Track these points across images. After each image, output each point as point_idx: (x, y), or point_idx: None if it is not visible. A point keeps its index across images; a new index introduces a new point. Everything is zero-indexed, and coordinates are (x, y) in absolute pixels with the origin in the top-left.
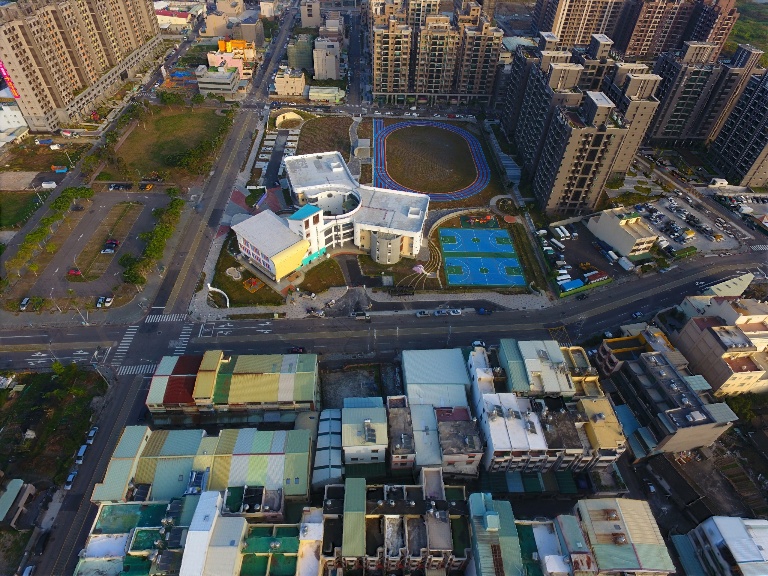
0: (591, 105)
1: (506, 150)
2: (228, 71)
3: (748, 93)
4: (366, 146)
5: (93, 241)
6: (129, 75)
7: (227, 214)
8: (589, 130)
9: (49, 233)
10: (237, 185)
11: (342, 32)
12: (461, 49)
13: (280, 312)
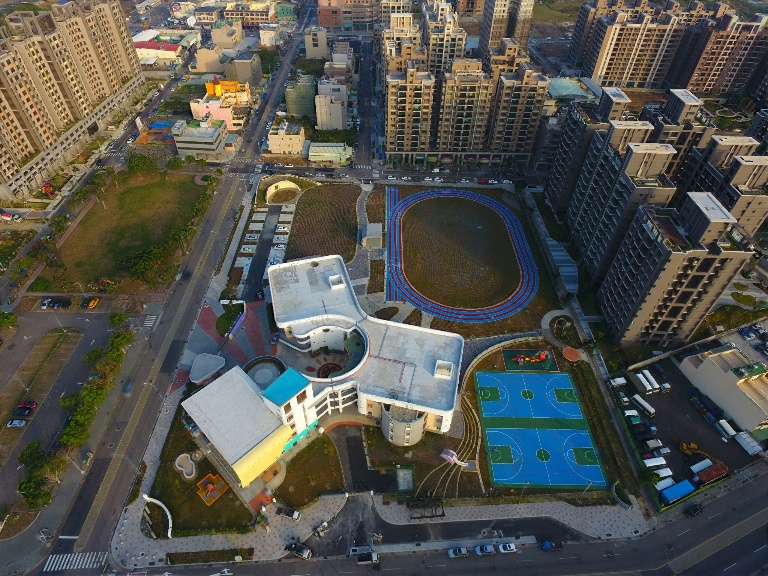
0: (696, 214)
1: (555, 234)
2: (213, 125)
3: None
4: (377, 235)
5: (1, 402)
6: (100, 127)
7: (190, 349)
8: (695, 253)
9: None
10: (208, 297)
11: (351, 67)
12: (495, 100)
13: (246, 547)
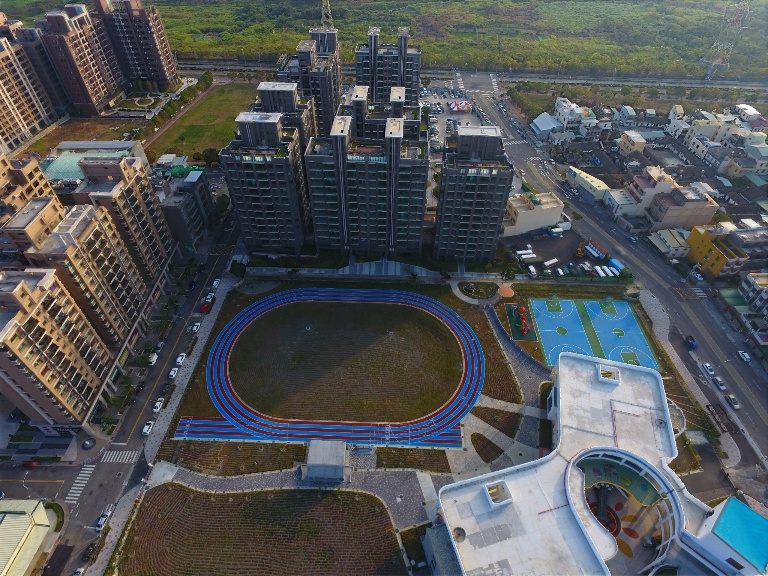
0: (481, 142)
1: (336, 264)
2: None
3: (364, 66)
4: (343, 448)
5: None
6: None
7: None
8: None
9: None
10: None
11: None
12: None
13: None
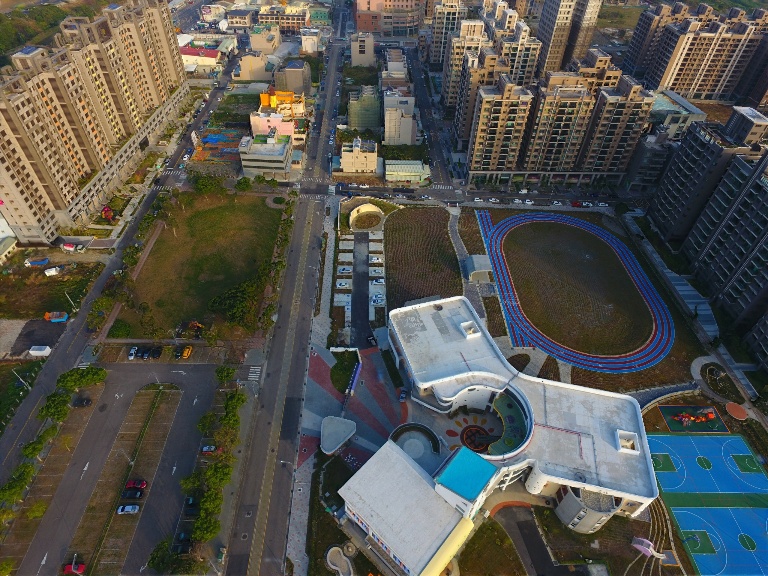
0: None
1: (673, 266)
2: (279, 141)
3: None
4: (487, 269)
5: (105, 480)
6: (150, 142)
7: (308, 409)
8: None
9: (35, 461)
10: (314, 343)
11: None
12: (592, 116)
13: None
